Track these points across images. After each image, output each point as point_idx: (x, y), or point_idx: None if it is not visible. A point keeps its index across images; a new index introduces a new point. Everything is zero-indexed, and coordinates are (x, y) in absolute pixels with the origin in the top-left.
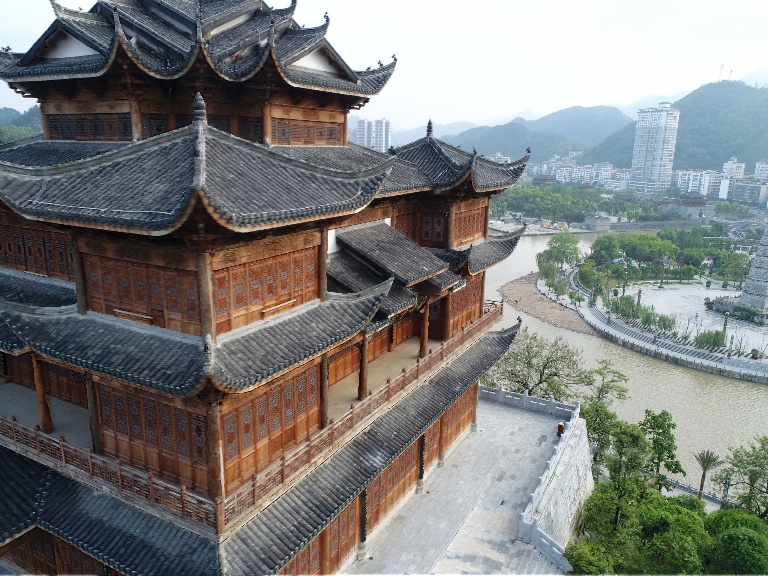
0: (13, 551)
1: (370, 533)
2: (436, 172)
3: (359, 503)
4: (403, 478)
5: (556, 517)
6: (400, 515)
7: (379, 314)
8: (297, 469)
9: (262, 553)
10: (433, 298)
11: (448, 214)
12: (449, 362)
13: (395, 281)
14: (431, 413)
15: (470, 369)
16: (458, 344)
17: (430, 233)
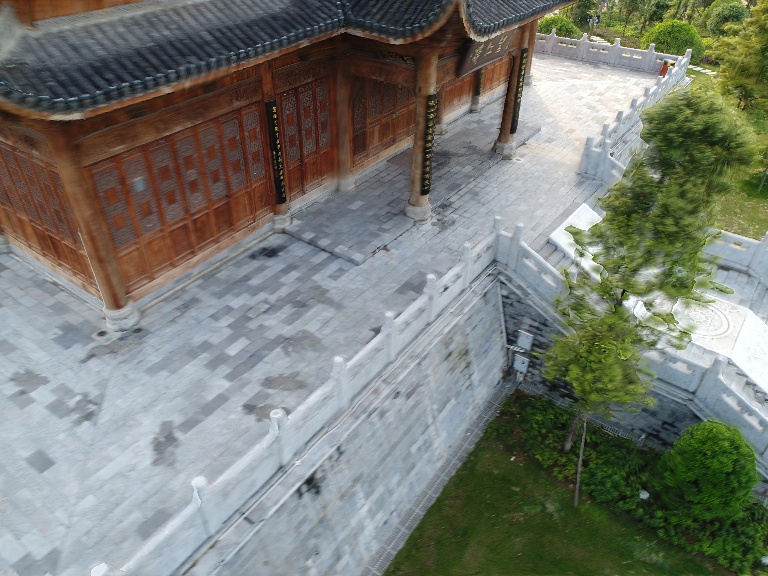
0: (383, 134)
1: None
2: None
3: None
4: None
5: None
6: None
7: None
8: None
9: None
10: None
11: None
12: None
13: None
14: None
15: None
16: None
17: None
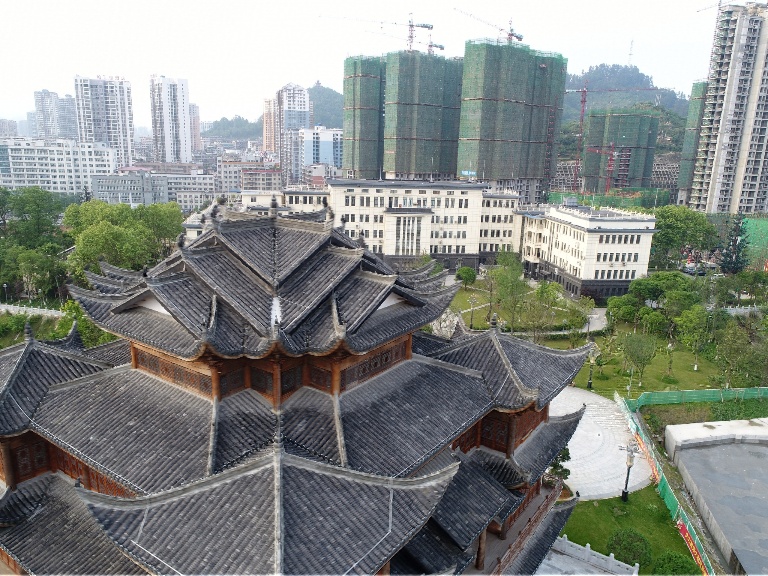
0: None
1: None
2: (75, 351)
3: None
4: None
5: None
6: None
7: None
8: None
9: None
10: None
11: None
12: None
13: None
14: None
15: None
16: None
17: None
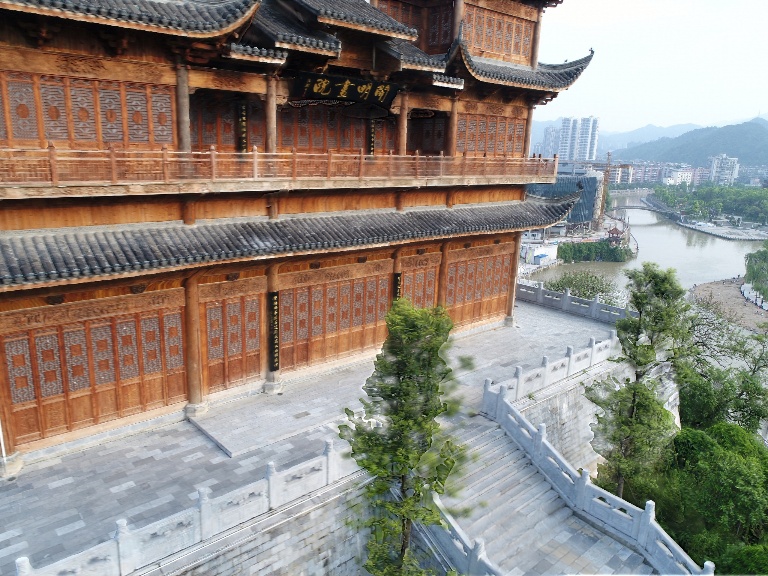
0: None
1: (292, 370)
2: None
3: (266, 318)
4: (360, 326)
5: (575, 424)
6: (349, 369)
7: (267, 43)
8: (87, 179)
9: (17, 264)
10: (419, 103)
11: (454, 1)
12: (454, 207)
13: (311, 19)
14: (385, 234)
15: (482, 220)
16: (453, 171)
17: (437, 35)
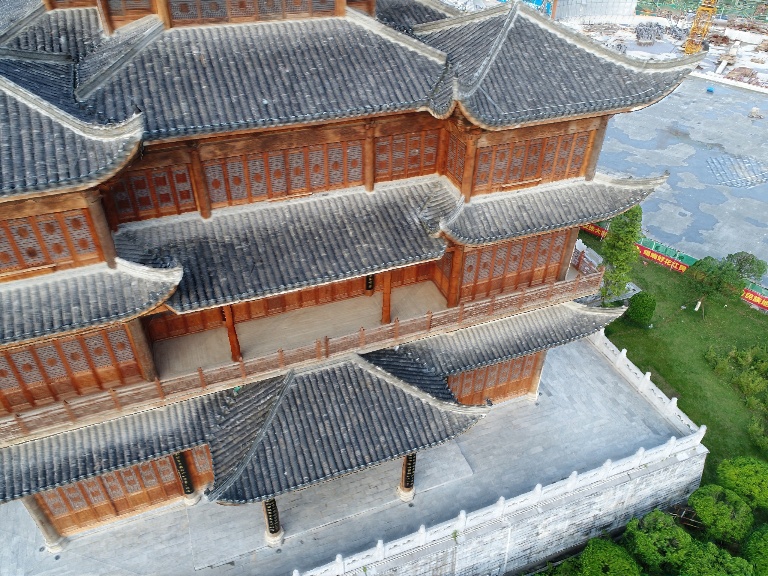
0: None
1: None
2: None
3: None
4: None
5: None
6: None
7: None
8: None
9: None
10: None
11: None
12: None
13: None
14: None
15: None
16: None
17: None
